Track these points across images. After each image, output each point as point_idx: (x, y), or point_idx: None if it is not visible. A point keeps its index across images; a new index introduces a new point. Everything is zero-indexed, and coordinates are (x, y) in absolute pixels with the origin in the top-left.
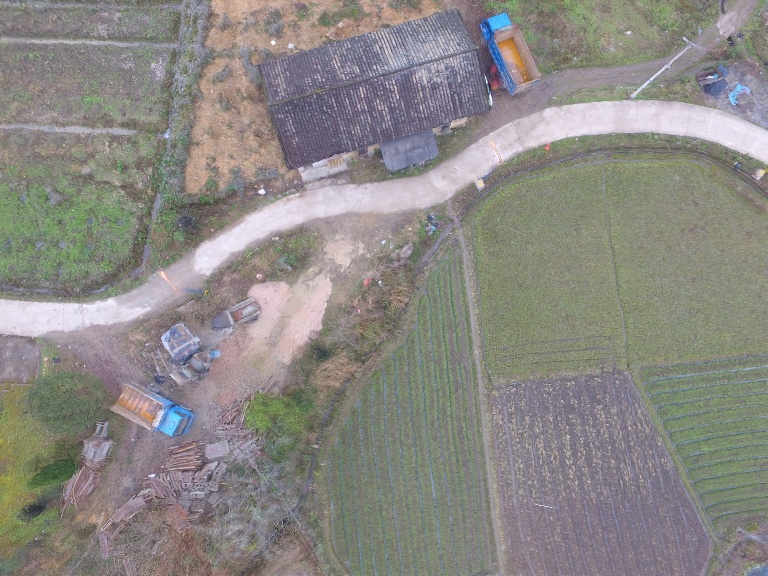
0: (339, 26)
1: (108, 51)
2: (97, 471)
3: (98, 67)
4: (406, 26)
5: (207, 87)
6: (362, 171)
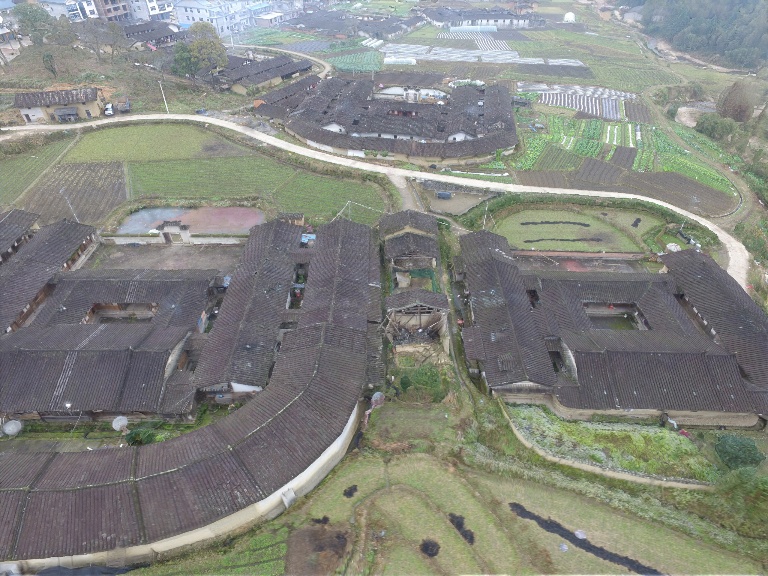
0: None
1: None
2: None
3: None
4: None
5: (9, 109)
6: None
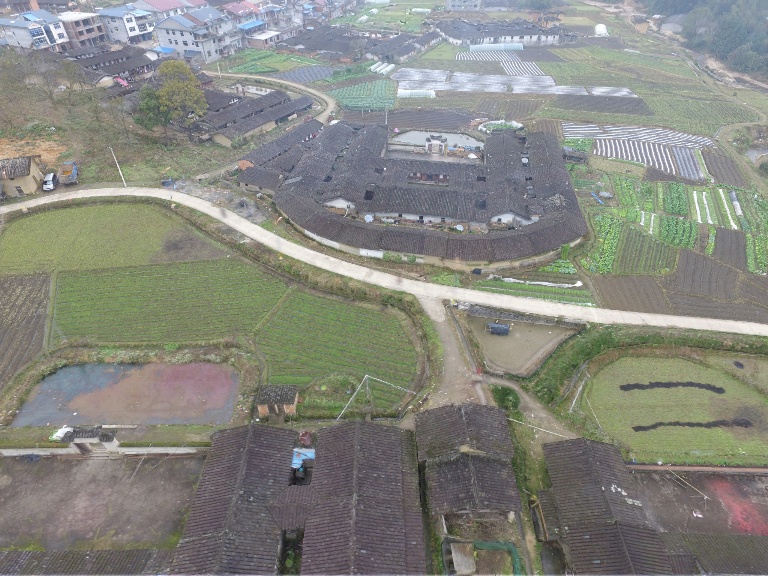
0: None
1: None
2: None
3: None
4: None
5: None
6: None
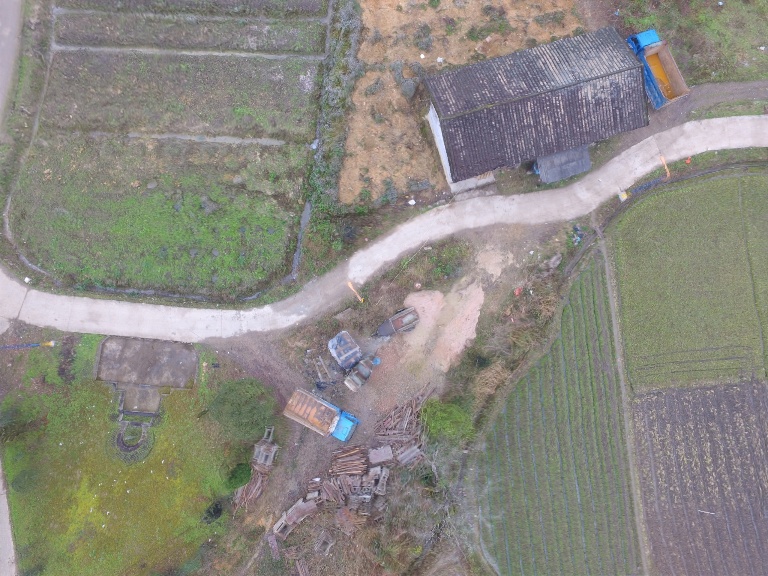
0: (487, 40)
1: (258, 63)
2: (265, 474)
3: (248, 79)
4: (566, 42)
5: (360, 99)
6: (509, 183)
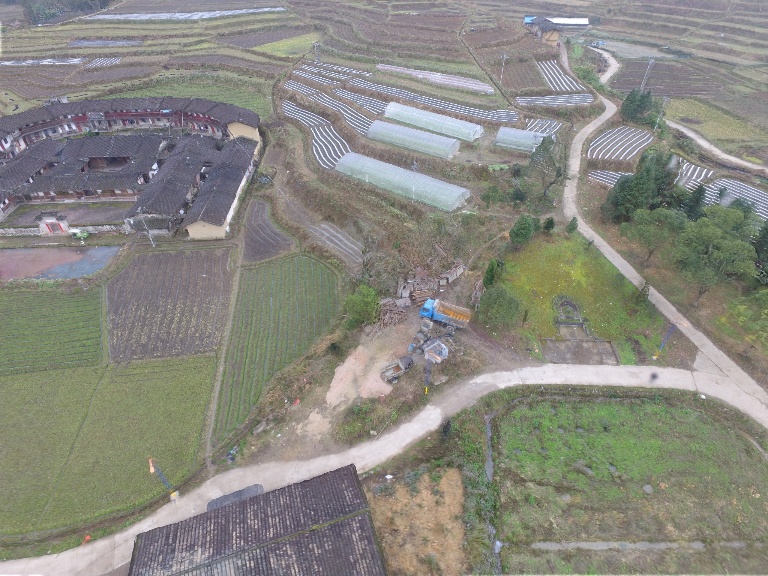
0: None
1: None
2: None
3: None
4: None
5: None
6: None
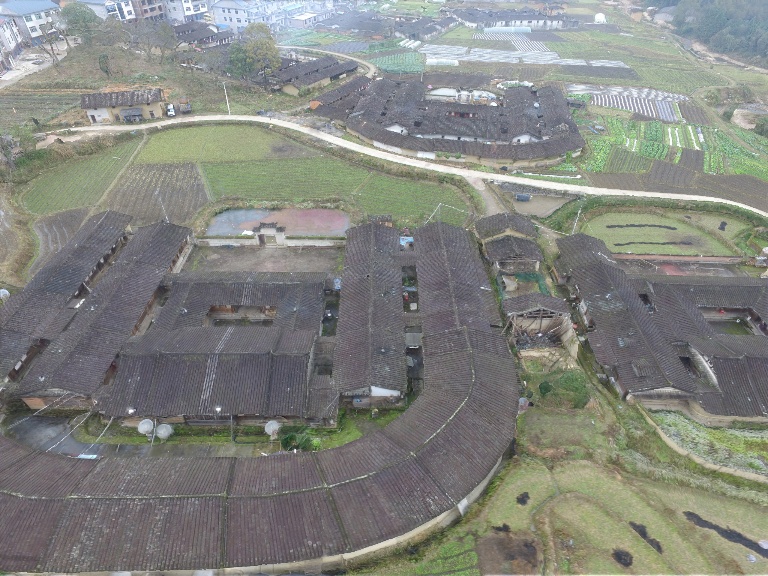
0: None
1: None
2: None
3: None
4: None
5: None
6: None
